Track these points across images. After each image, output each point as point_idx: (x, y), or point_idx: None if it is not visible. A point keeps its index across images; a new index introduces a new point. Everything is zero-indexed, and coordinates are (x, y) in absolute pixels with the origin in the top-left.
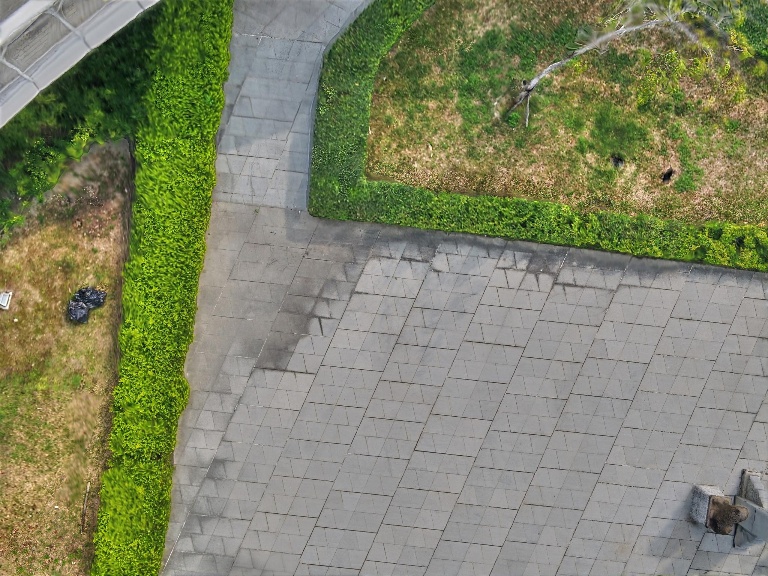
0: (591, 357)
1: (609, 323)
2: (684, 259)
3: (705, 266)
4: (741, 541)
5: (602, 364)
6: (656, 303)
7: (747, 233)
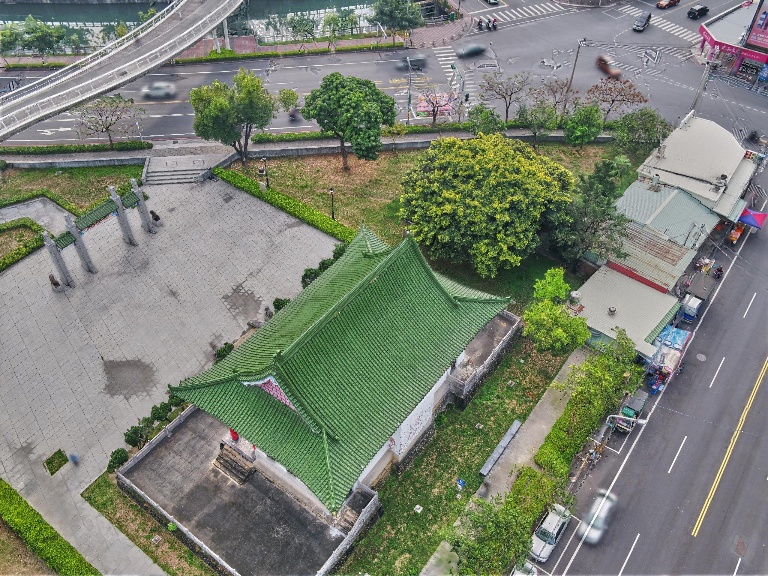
0: (2, 295)
1: (0, 288)
2: (3, 268)
3: (12, 266)
4: (71, 285)
5: (6, 294)
6: (7, 278)
7: (11, 254)
